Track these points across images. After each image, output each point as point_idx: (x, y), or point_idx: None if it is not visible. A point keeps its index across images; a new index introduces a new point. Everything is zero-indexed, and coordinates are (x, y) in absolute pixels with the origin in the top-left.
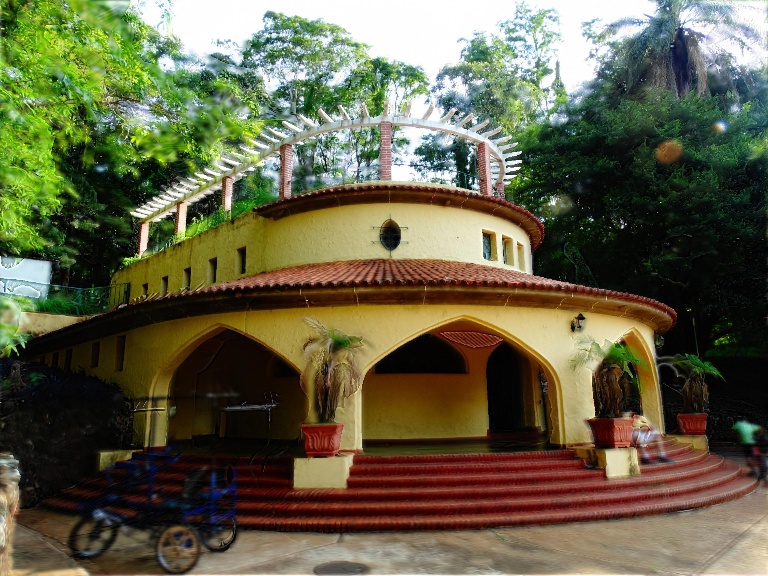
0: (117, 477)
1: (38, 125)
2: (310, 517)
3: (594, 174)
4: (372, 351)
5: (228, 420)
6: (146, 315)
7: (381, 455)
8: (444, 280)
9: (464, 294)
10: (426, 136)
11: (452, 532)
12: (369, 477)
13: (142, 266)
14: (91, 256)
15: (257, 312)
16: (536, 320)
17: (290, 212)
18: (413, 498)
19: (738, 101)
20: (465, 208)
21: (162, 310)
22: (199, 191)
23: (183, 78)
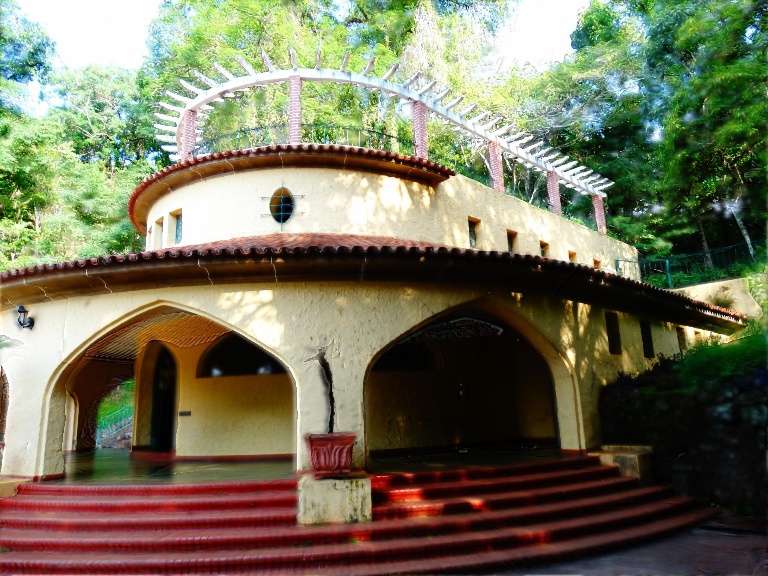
0: None
1: None
2: None
3: None
4: None
5: None
6: None
7: None
8: None
9: None
10: None
11: None
12: None
13: None
14: None
15: None
16: None
17: None
18: None
19: None
20: None
21: None
22: None
23: (662, 1)
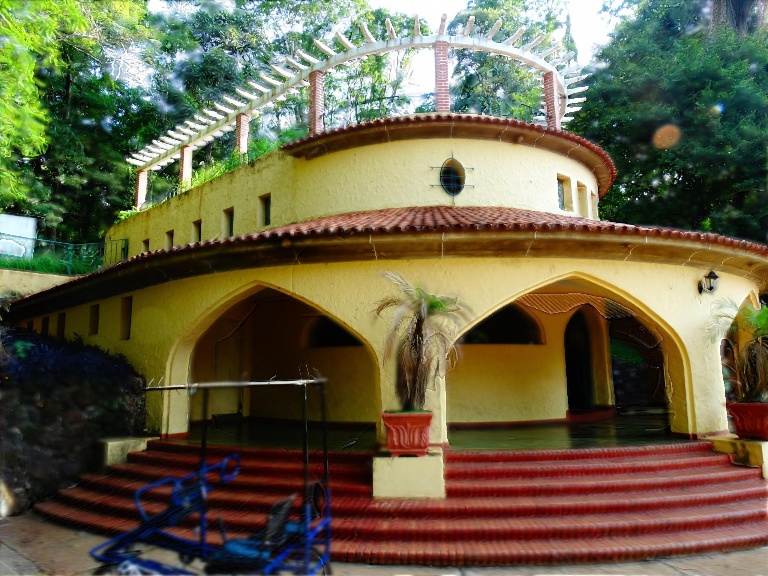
0: (131, 475)
1: (15, 39)
2: (408, 541)
3: (647, 122)
4: (461, 317)
5: (253, 397)
6: (160, 270)
7: (478, 451)
8: (560, 224)
9: (580, 244)
10: None
11: (613, 566)
12: (472, 482)
13: (142, 219)
14: (79, 215)
15: (308, 266)
16: (661, 279)
17: (327, 150)
18: (540, 513)
19: None
20: (539, 147)
21: (182, 264)
22: (207, 132)
23: (176, 19)
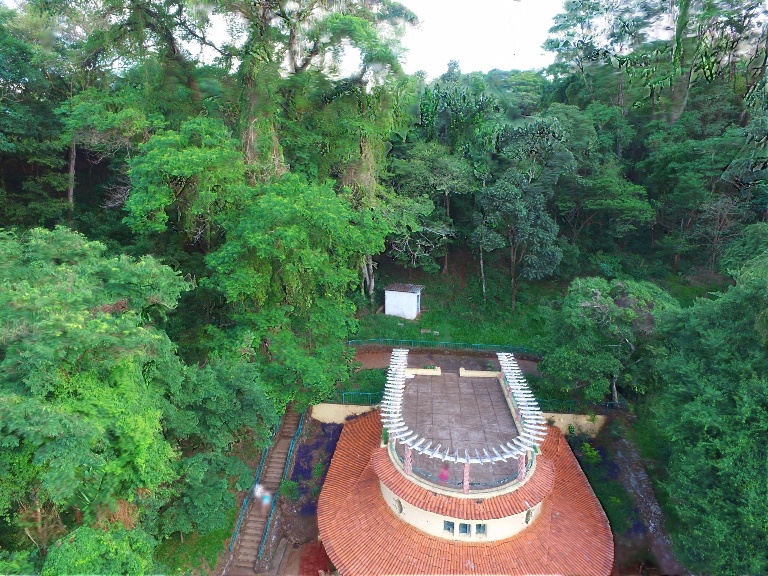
0: (315, 551)
1: None
2: None
3: None
4: None
5: None
6: None
7: None
8: None
9: None
10: None
11: None
12: None
13: None
14: None
15: None
16: None
17: None
18: None
19: None
20: None
21: None
22: None
23: None
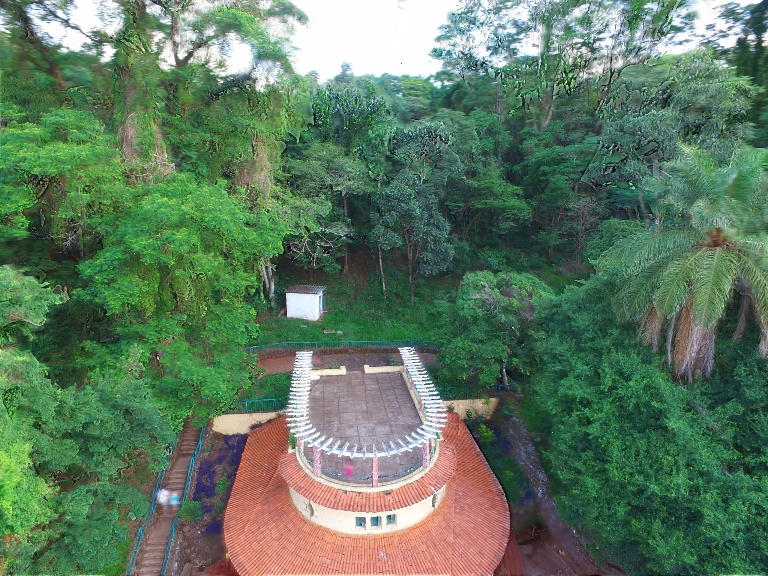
0: (224, 570)
1: None
2: None
3: None
4: None
5: None
6: None
7: None
8: None
9: None
10: (720, 4)
11: None
12: None
13: None
14: None
15: None
16: None
17: None
18: None
19: (764, 353)
20: None
21: None
22: None
23: None
